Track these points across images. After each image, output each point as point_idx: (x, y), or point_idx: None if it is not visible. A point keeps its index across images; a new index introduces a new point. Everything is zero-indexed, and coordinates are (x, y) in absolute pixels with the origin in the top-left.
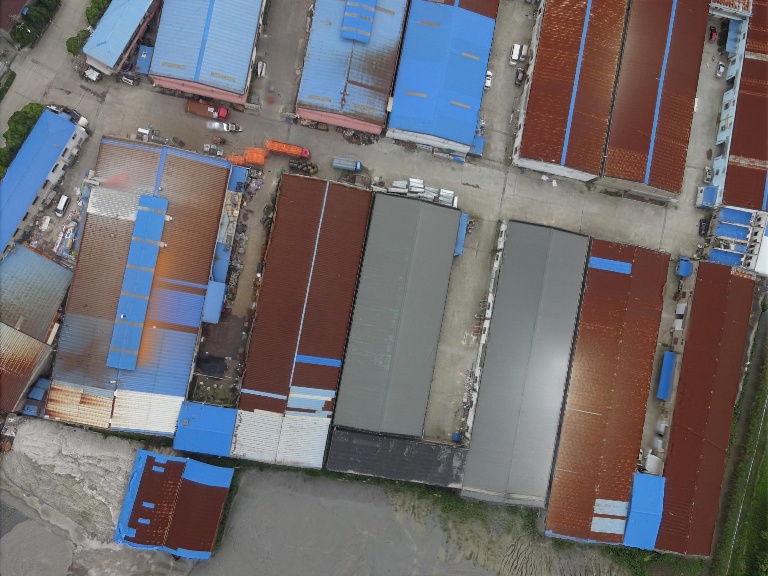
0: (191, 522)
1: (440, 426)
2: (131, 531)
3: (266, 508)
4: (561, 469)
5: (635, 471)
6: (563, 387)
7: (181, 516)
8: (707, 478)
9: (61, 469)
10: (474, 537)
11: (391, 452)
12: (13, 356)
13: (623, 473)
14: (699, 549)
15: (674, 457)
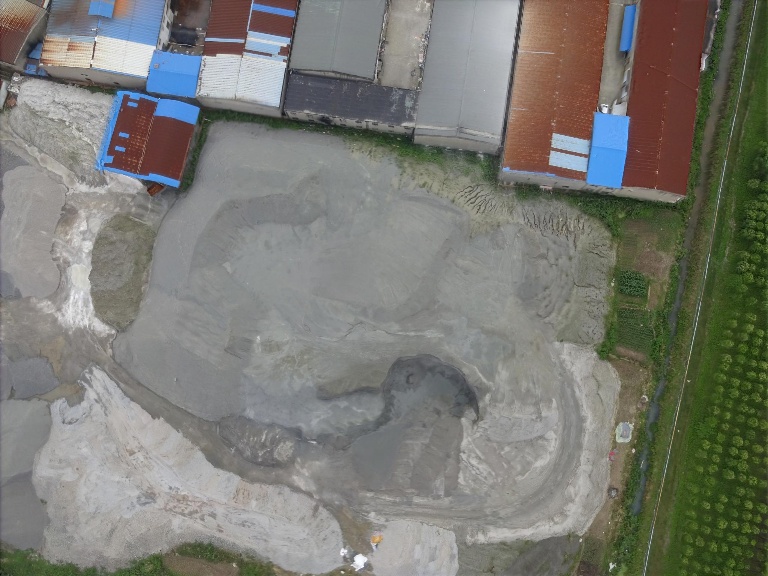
0: (161, 150)
1: (397, 85)
2: (109, 158)
3: (229, 145)
4: (516, 108)
5: (595, 110)
6: (514, 32)
7: (152, 146)
8: (675, 114)
9: (54, 115)
10: (429, 174)
11: (344, 93)
12: (15, 17)
13: (582, 111)
14: (671, 186)
15: (636, 93)
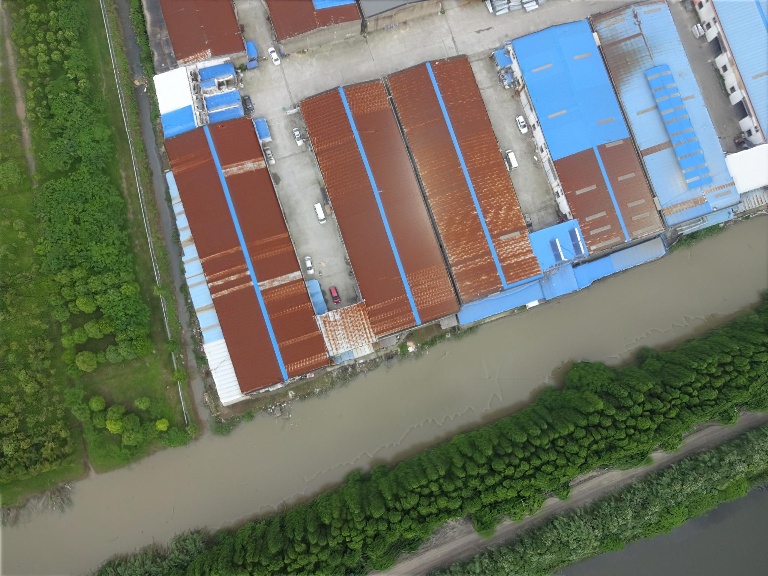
0: None
1: None
2: None
3: None
4: None
5: None
6: None
7: None
8: None
9: None
10: None
11: None
12: None
13: None
14: None
15: None
